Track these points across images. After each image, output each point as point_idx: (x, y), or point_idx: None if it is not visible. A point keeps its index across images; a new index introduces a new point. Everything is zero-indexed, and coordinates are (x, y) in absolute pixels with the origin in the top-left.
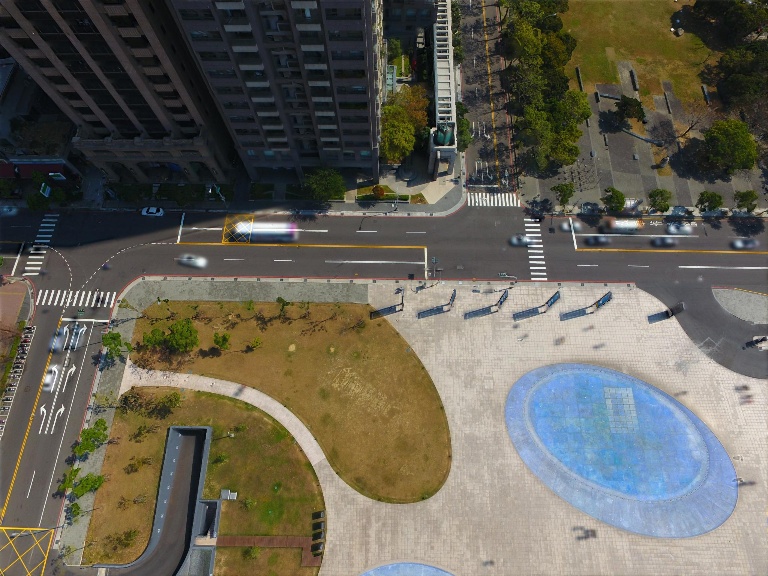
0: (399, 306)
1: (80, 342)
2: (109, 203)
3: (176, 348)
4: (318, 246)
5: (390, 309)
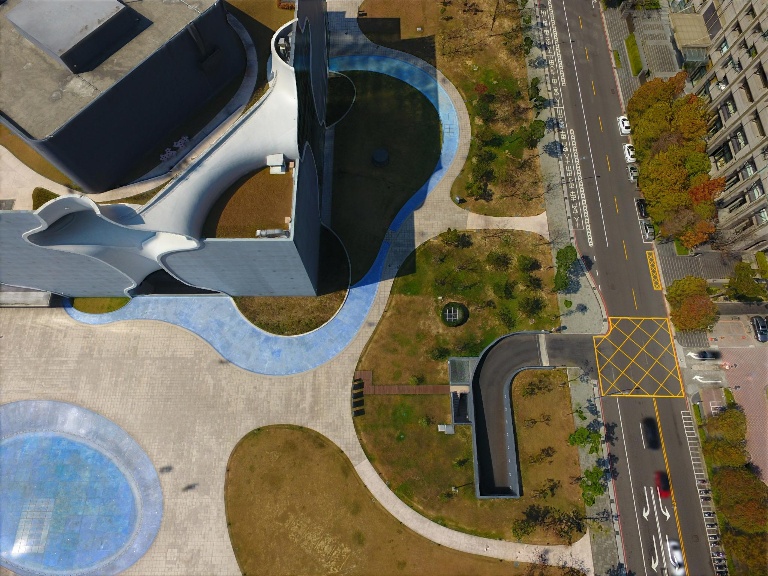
0: None
1: None
2: None
3: None
4: None
5: None
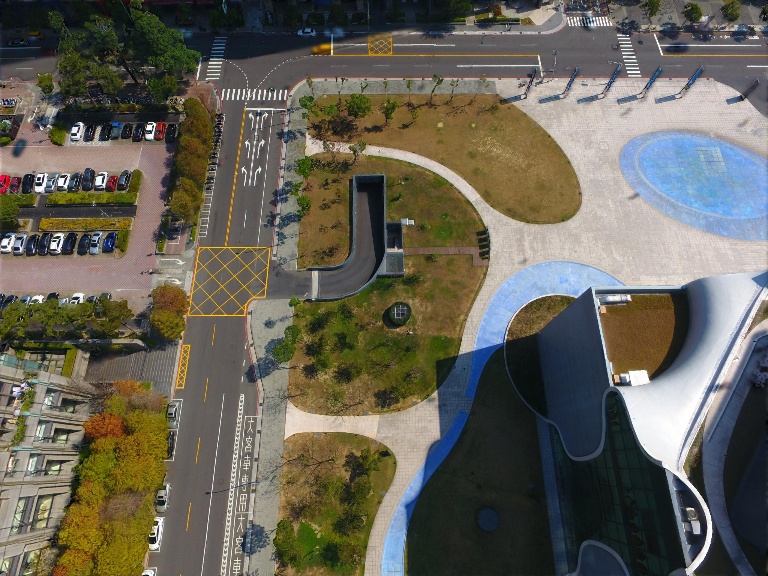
0: (523, 95)
1: (264, 124)
2: (268, 28)
3: (345, 126)
4: (449, 55)
5: (516, 97)
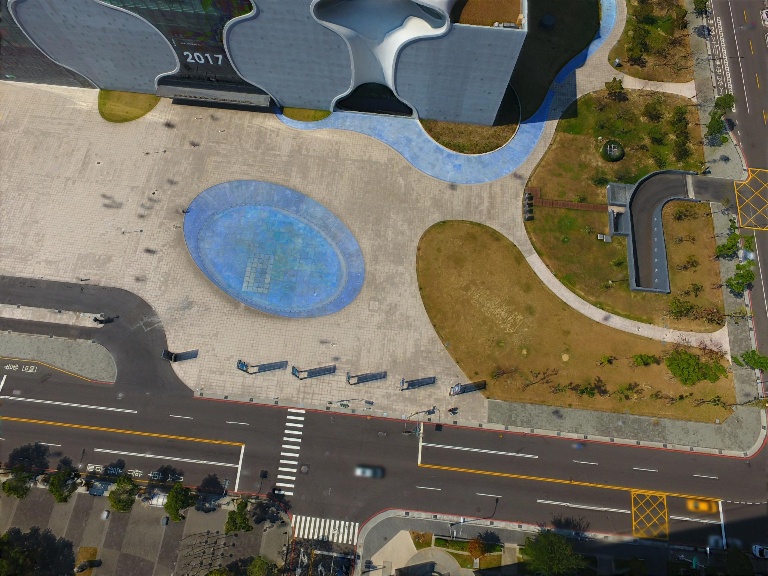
0: None
1: None
2: None
3: None
4: (548, 479)
5: (464, 390)
